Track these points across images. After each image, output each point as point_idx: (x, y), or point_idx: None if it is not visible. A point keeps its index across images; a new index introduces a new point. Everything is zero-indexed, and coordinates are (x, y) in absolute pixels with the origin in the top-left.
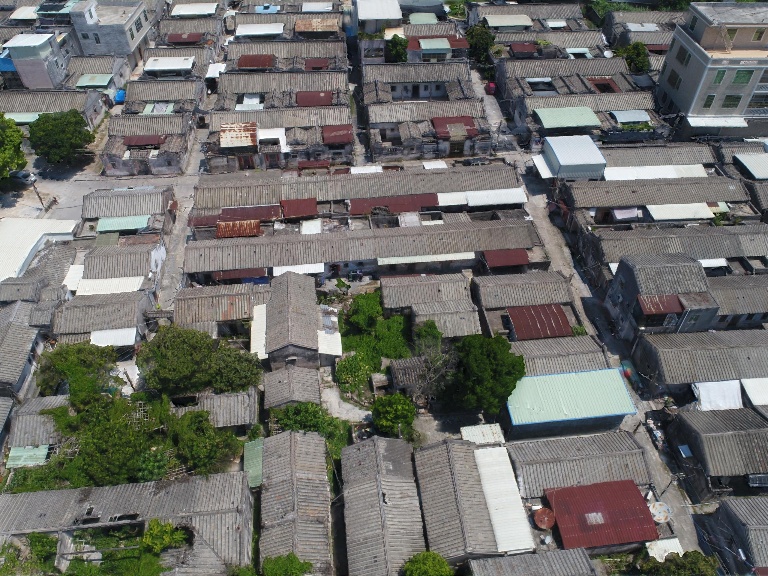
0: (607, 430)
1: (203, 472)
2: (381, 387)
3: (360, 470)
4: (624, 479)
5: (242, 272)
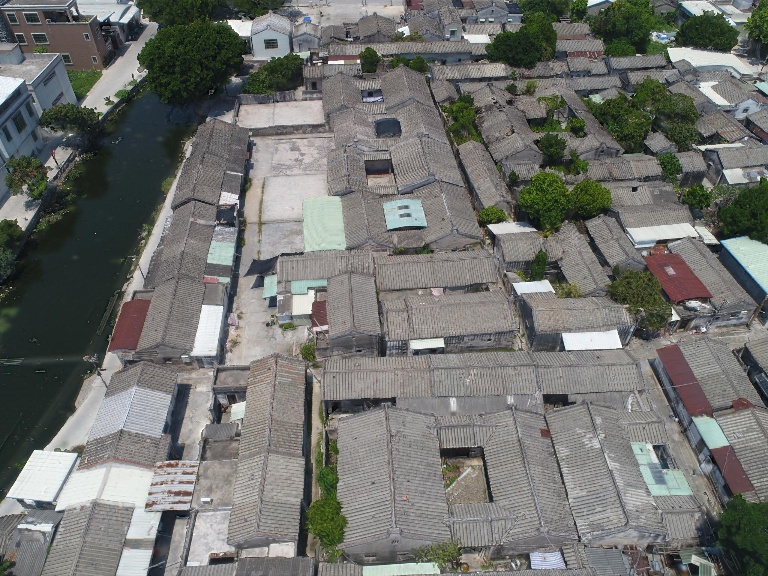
0: (760, 317)
1: (616, 139)
2: (717, 205)
3: (648, 184)
4: (711, 293)
5: (767, 137)
